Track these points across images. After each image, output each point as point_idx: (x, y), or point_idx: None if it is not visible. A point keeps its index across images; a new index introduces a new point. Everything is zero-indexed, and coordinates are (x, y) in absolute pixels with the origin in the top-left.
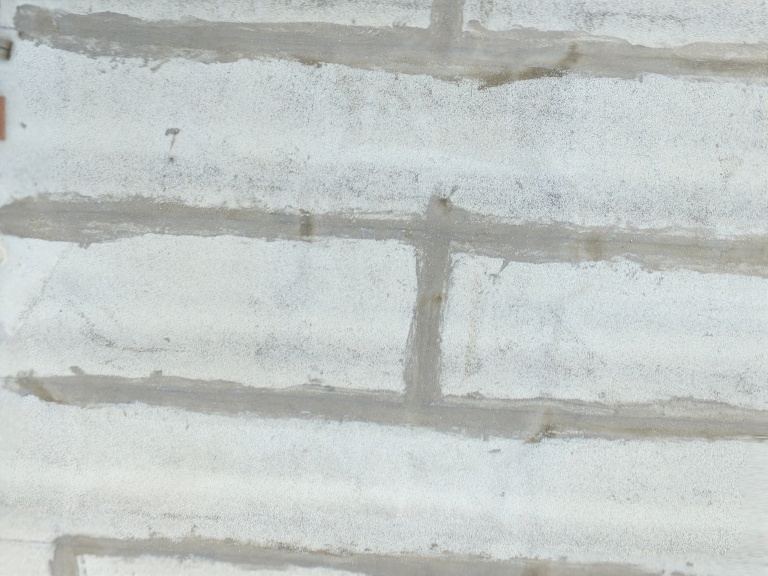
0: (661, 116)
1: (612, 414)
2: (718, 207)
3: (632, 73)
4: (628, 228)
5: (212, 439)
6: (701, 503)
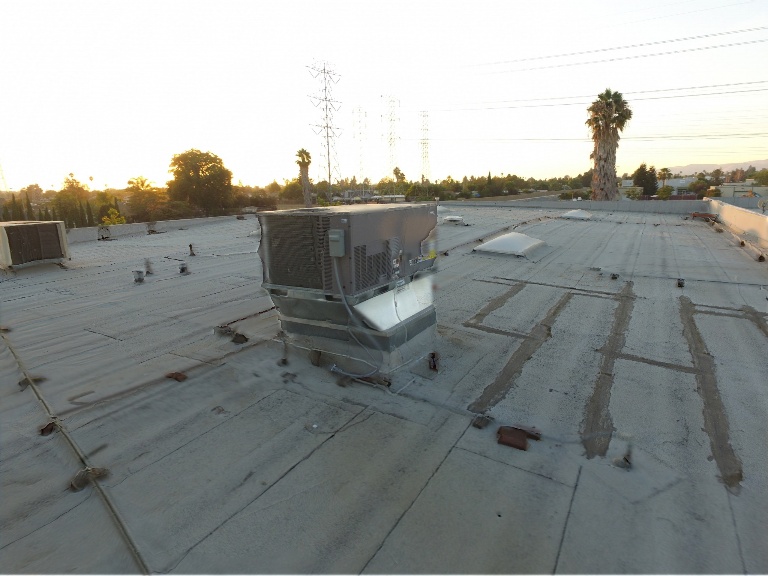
0: None
1: None
2: None
3: None
4: (611, 329)
5: (747, 424)
6: None
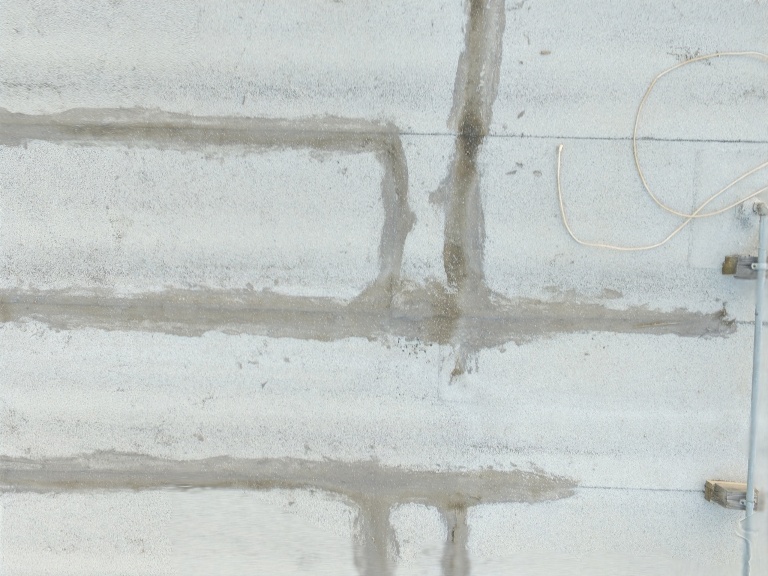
0: (50, 181)
1: (39, 469)
2: (115, 267)
3: (16, 140)
4: (30, 290)
5: None
6: (133, 551)
